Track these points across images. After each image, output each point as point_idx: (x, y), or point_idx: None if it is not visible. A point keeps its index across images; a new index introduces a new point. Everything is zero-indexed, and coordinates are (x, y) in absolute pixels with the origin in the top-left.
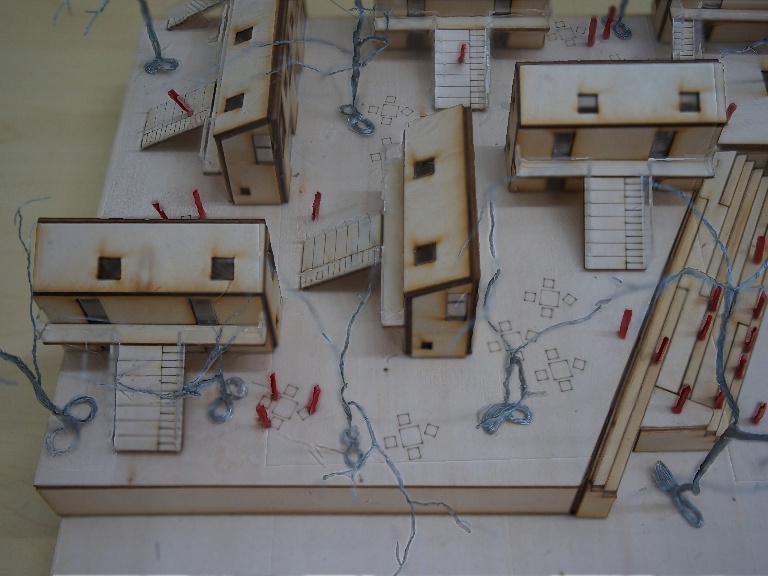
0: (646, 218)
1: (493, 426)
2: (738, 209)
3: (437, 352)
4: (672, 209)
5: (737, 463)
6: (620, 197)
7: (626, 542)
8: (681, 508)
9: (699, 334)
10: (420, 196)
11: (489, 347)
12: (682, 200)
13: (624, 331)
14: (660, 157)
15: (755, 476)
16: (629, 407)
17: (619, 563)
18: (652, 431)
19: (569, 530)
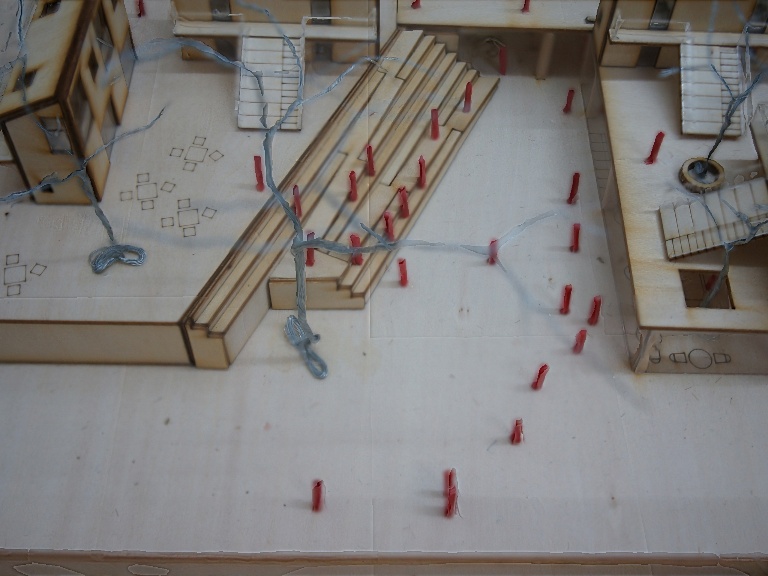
0: (315, 86)
1: (101, 265)
2: (418, 85)
3: (60, 196)
4: (344, 79)
5: (376, 321)
6: (278, 57)
7: (243, 391)
8: (306, 360)
9: (349, 194)
10: (39, 31)
11: (121, 196)
12: (356, 71)
13: (259, 182)
14: (324, 21)
15: (391, 333)
16: (252, 254)
17: (230, 410)
18: (281, 282)
19: (187, 380)
